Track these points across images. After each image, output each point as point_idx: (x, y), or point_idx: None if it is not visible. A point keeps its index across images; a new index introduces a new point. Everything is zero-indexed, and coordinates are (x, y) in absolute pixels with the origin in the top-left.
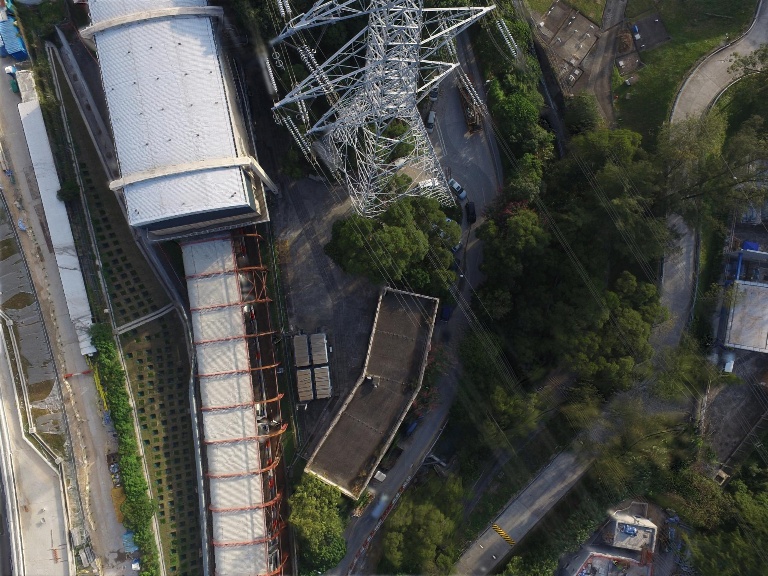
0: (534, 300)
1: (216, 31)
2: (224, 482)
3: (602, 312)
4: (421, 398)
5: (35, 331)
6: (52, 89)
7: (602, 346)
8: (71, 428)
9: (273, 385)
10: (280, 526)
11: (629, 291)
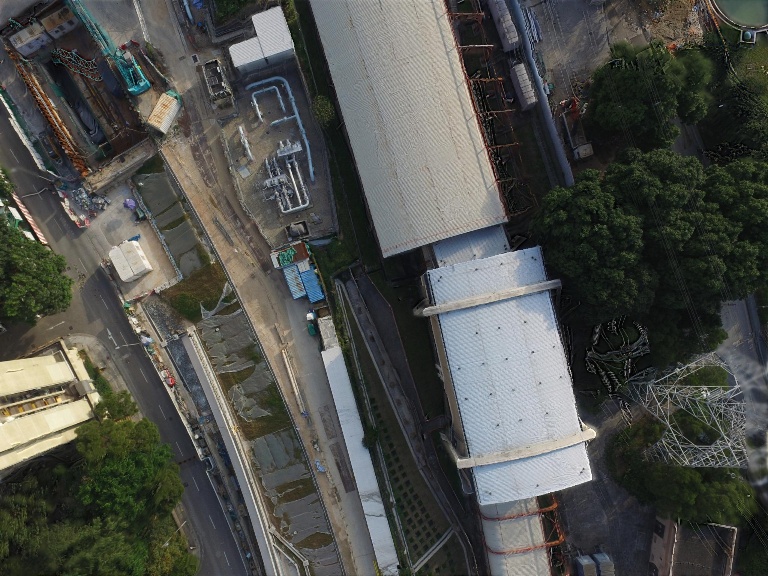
0: None
1: (555, 303)
2: None
3: None
4: None
5: (332, 572)
6: None
7: None
8: None
9: None
10: None
11: None
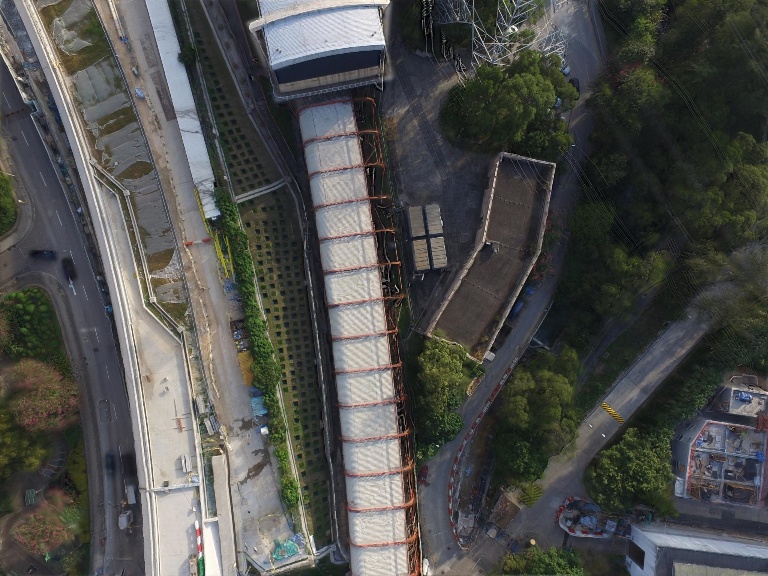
0: (651, 162)
1: None
2: (351, 344)
3: (724, 167)
4: (539, 264)
5: (153, 200)
6: None
7: (725, 201)
8: (192, 297)
9: (393, 252)
10: (403, 393)
11: (747, 149)
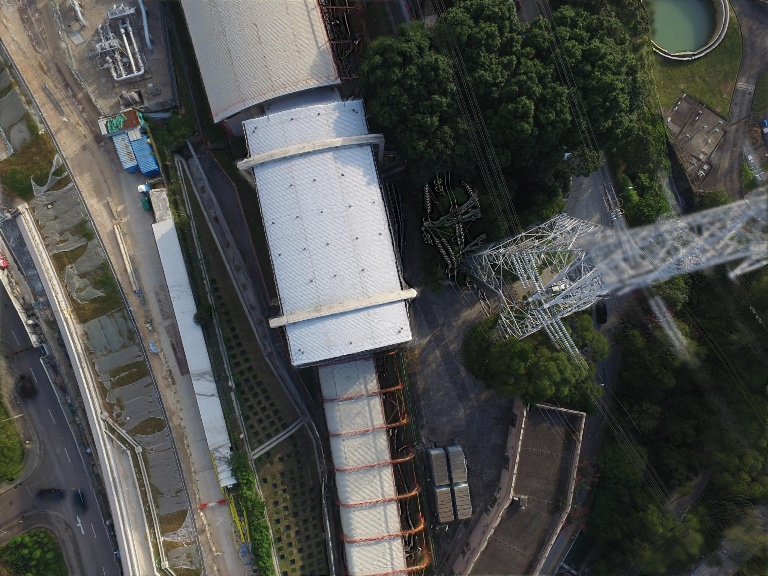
0: (686, 413)
1: (377, 159)
2: None
3: (764, 429)
4: (569, 517)
5: (166, 458)
6: (184, 205)
7: (765, 465)
8: (206, 562)
9: (416, 509)
10: None
11: None
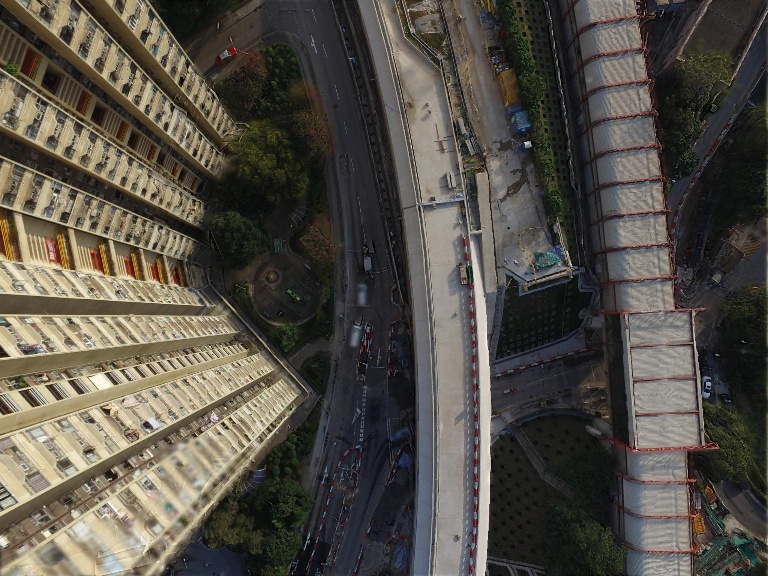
0: None
1: None
2: (609, 61)
3: None
4: None
5: None
6: None
7: None
8: (449, 27)
9: None
10: None
11: None
